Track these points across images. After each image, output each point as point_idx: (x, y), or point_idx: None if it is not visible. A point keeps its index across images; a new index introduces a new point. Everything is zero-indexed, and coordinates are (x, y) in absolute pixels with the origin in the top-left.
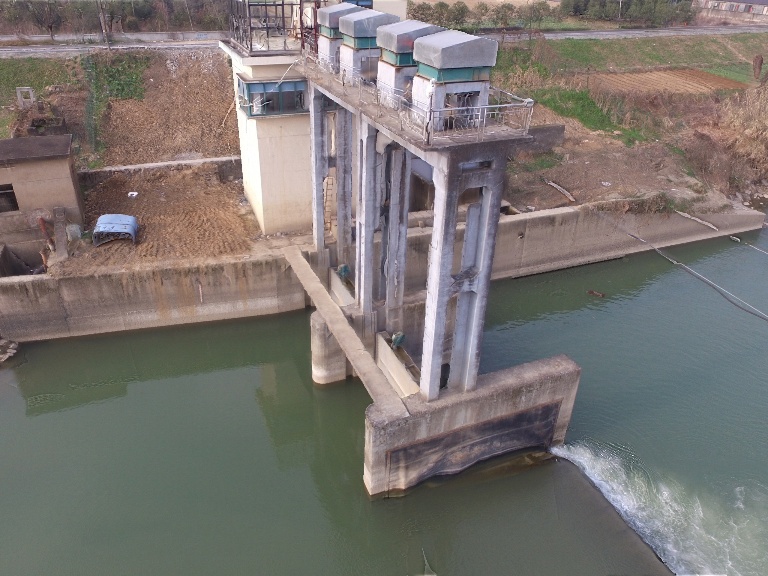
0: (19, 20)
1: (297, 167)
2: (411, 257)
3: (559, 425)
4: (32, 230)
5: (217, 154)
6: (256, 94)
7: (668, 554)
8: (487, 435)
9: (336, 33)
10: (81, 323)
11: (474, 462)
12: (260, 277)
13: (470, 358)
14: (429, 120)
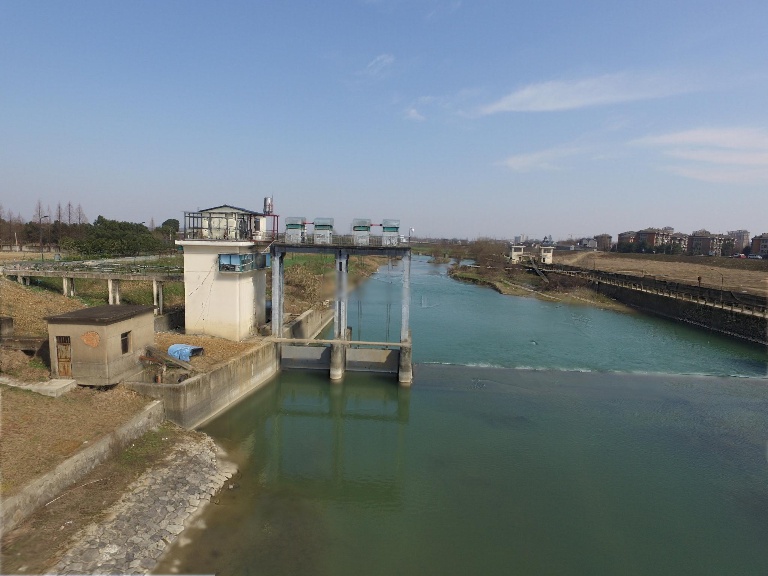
0: None
1: (246, 300)
2: (292, 337)
3: None
4: (135, 366)
5: None
6: None
7: None
8: None
9: None
10: (214, 405)
11: None
12: (268, 354)
13: None
14: (409, 239)
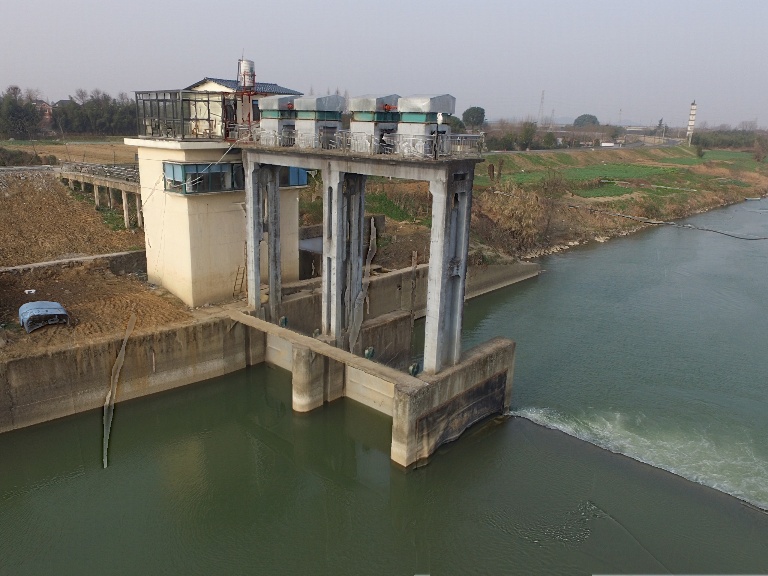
0: None
1: (220, 241)
2: None
3: (507, 393)
4: None
5: (101, 252)
6: (189, 175)
7: (615, 452)
8: (470, 403)
9: (282, 114)
10: (27, 412)
11: (464, 429)
12: (209, 339)
13: (457, 334)
14: (436, 142)
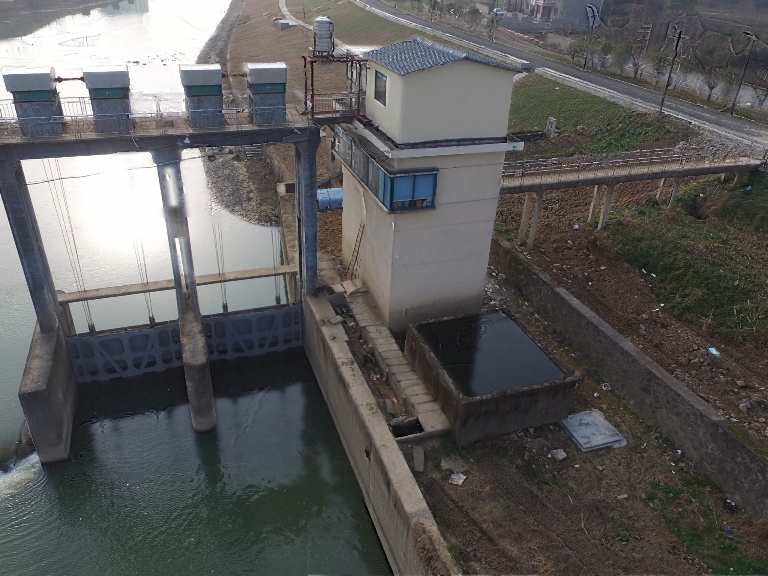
0: (689, 74)
1: None
2: None
3: None
4: None
5: None
6: None
7: None
8: None
9: None
10: None
11: None
12: None
13: None
14: None
